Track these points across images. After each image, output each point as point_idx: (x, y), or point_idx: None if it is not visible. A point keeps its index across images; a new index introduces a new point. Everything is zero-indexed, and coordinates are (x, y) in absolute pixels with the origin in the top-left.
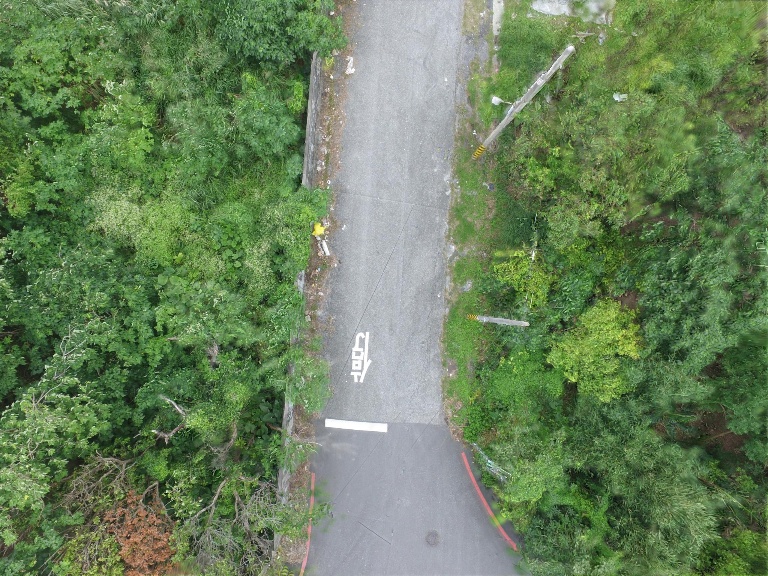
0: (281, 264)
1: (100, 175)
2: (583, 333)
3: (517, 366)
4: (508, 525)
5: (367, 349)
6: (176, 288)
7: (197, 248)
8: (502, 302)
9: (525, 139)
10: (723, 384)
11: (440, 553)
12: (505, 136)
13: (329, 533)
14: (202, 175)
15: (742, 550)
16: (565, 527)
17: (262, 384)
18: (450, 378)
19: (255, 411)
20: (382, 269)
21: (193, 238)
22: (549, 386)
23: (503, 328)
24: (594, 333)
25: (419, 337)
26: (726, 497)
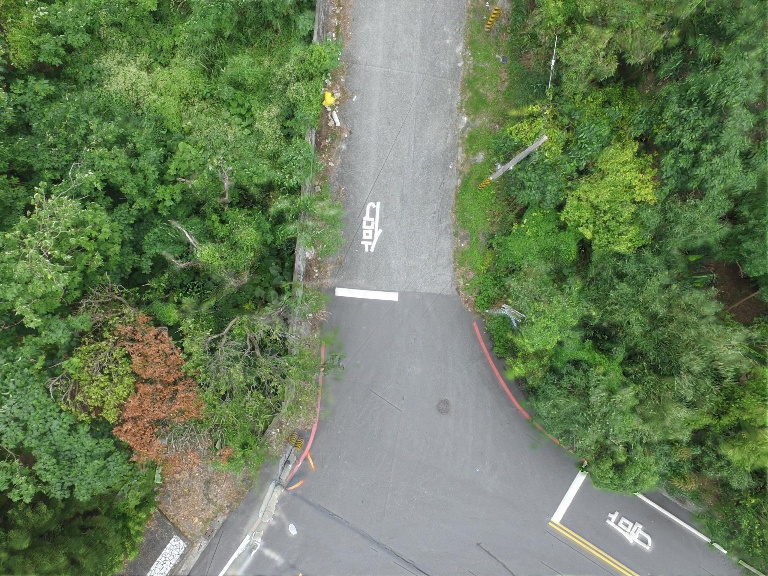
0: (291, 126)
1: (108, 37)
2: (599, 179)
3: (530, 228)
4: (520, 395)
5: (378, 218)
6: (185, 154)
7: (206, 118)
8: (515, 172)
9: (539, 11)
10: (742, 231)
11: (451, 421)
12: (518, 7)
13: (339, 400)
14: (212, 35)
15: (761, 388)
16: (579, 379)
17: (272, 239)
18: (462, 248)
19: (265, 276)
20: (393, 139)
21: (202, 107)
22: (563, 247)
23: (516, 199)
24: (611, 174)
25: (430, 207)
26: (743, 349)
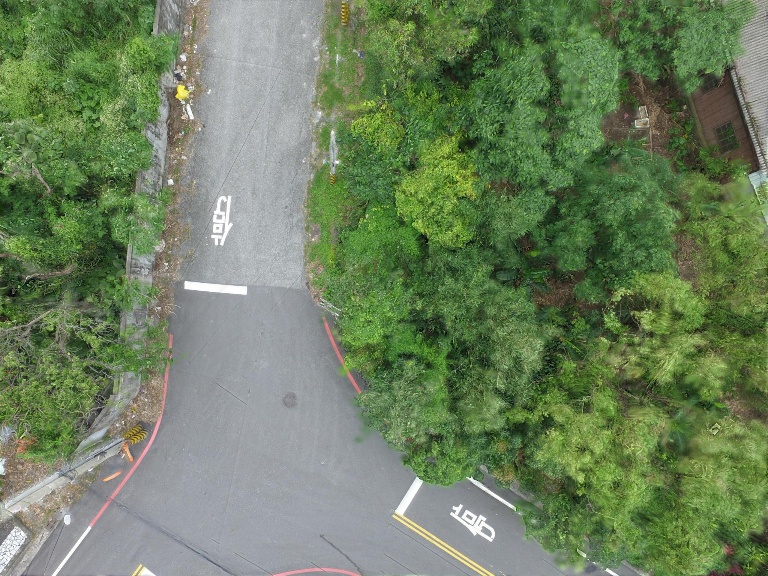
0: (136, 119)
1: None
2: (422, 174)
3: (371, 223)
4: None
5: (229, 212)
6: (33, 146)
7: (59, 110)
8: None
9: (396, 5)
10: (562, 227)
11: (297, 415)
12: None
13: (185, 393)
14: (54, 26)
15: (566, 383)
16: (405, 374)
17: (106, 232)
18: (312, 243)
19: (110, 269)
20: (246, 133)
21: (54, 99)
22: (402, 243)
23: None
24: (428, 170)
25: (282, 202)
26: (567, 345)
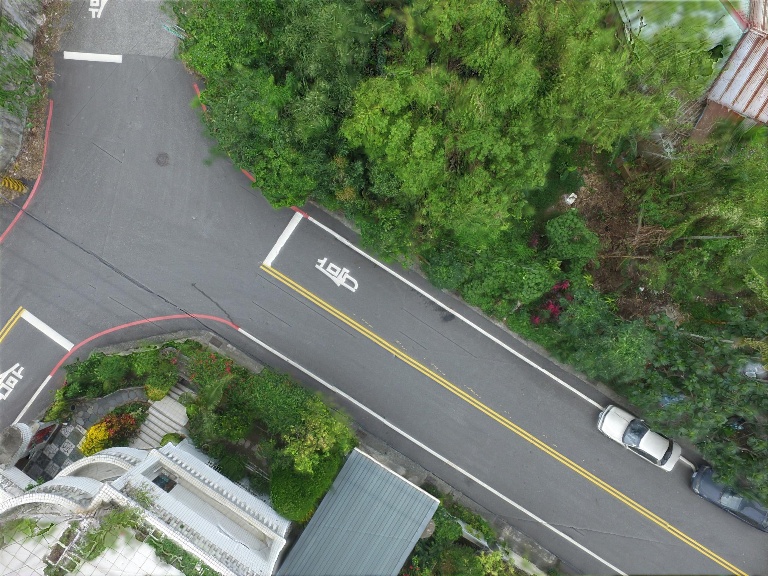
0: None
1: None
2: None
3: None
4: None
5: None
6: None
7: None
8: None
9: None
10: None
11: (170, 174)
12: None
13: (64, 153)
14: None
15: None
16: None
17: None
18: None
19: None
20: None
21: None
22: None
23: None
24: None
25: None
26: None
